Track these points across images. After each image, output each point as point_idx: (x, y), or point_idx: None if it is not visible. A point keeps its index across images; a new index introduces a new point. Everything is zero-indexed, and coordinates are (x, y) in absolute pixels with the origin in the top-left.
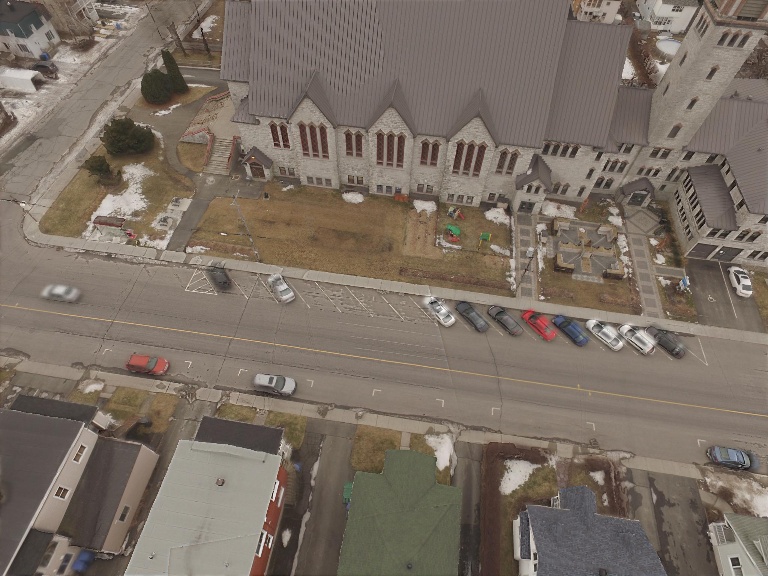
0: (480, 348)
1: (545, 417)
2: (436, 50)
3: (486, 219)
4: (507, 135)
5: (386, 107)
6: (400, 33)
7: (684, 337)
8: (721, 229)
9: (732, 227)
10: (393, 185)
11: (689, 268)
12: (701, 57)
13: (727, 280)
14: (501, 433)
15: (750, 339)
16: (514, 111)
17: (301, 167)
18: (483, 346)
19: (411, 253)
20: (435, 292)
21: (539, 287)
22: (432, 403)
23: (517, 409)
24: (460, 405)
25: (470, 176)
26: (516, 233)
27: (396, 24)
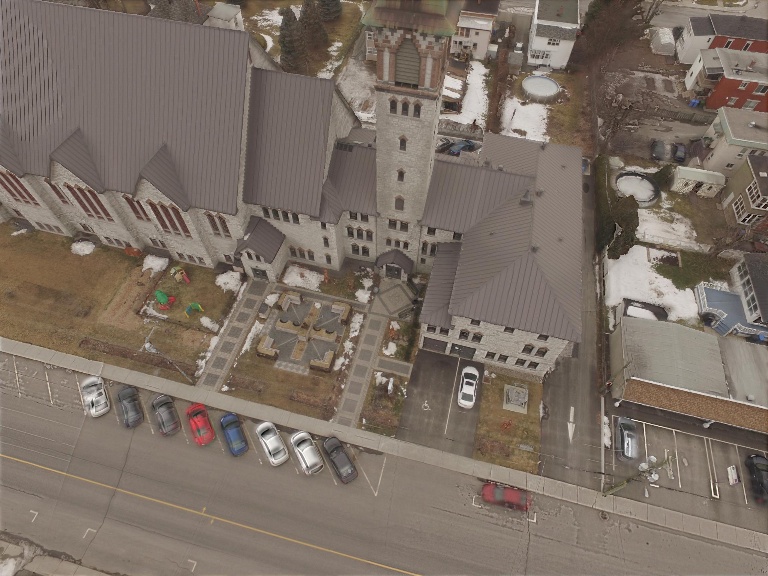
0: (117, 448)
1: (142, 548)
2: (114, 97)
3: (214, 284)
4: (197, 198)
5: (49, 160)
6: (75, 76)
7: (368, 454)
8: (436, 326)
9: (446, 325)
10: (119, 238)
11: (419, 363)
12: (381, 125)
13: (457, 383)
14: (80, 564)
15: (448, 464)
16: (201, 171)
17: (23, 212)
18: (122, 446)
19: (106, 321)
20: (106, 371)
21: (229, 374)
22: (22, 515)
23: (115, 533)
24: (53, 521)
25: (184, 237)
26: (239, 304)
27: (70, 66)
